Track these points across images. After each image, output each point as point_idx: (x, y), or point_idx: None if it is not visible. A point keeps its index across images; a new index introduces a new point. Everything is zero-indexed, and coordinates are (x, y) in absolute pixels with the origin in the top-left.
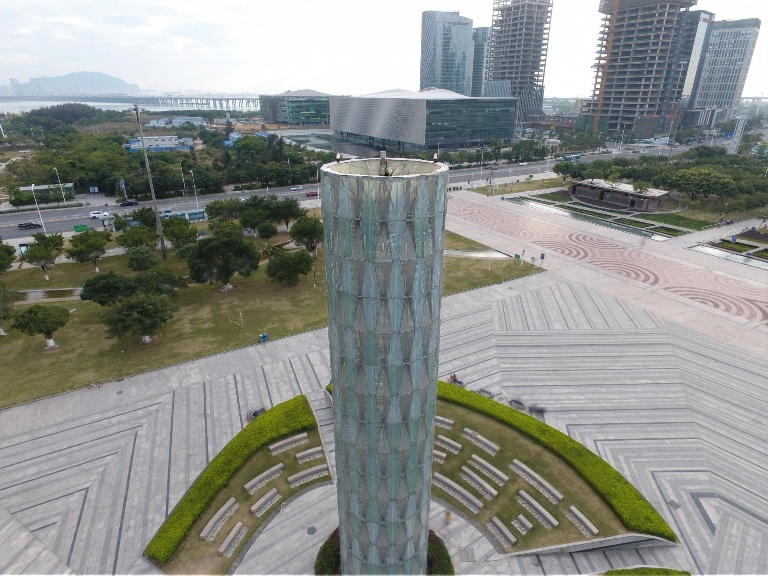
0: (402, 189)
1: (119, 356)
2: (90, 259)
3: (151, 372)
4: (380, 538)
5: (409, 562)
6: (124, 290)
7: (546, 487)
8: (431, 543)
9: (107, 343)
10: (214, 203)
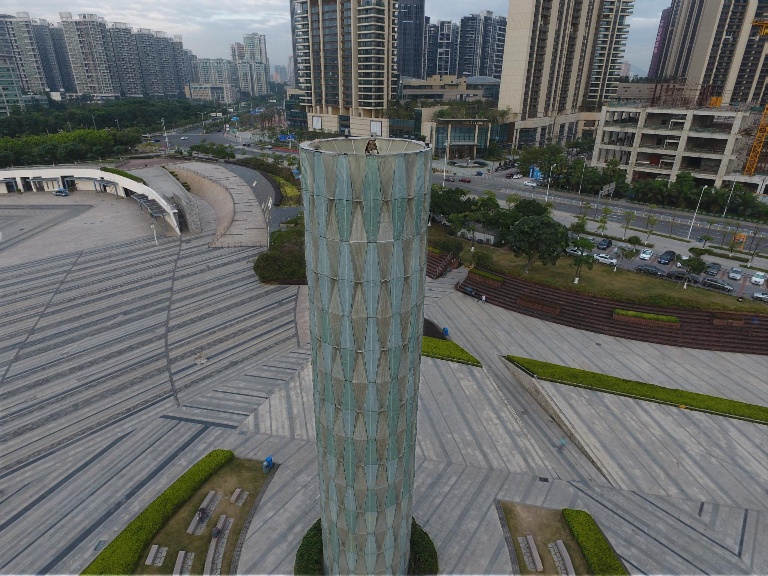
0: None
1: None
2: None
3: None
4: None
5: None
6: None
7: None
8: None
9: None
10: None
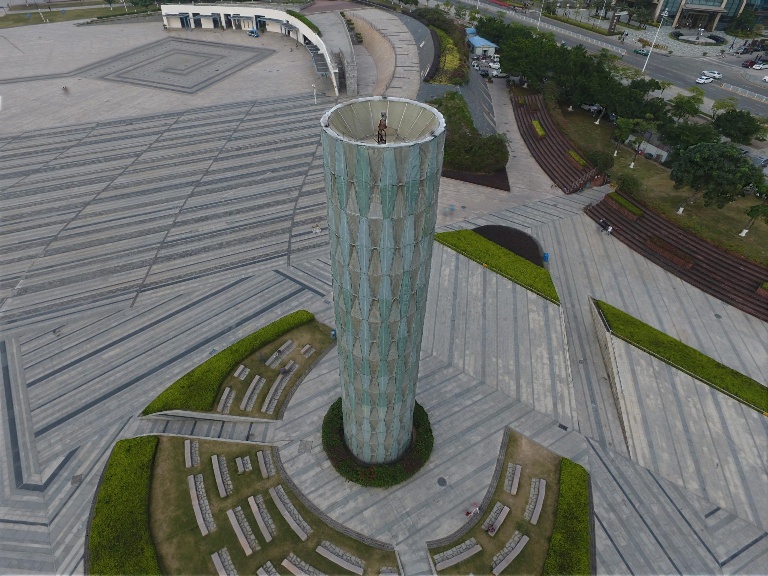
0: None
1: None
2: None
3: None
4: None
5: None
6: None
7: (196, 491)
8: (335, 446)
9: None
10: None
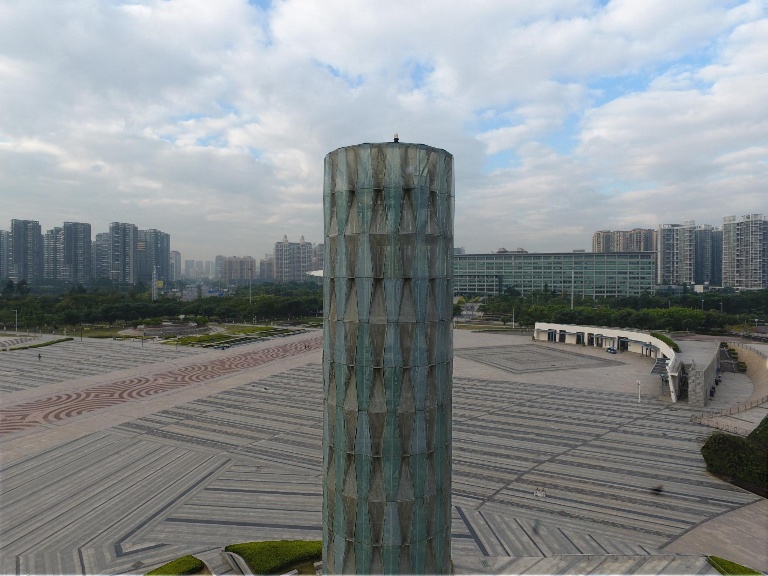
0: None
1: None
2: None
3: None
4: None
5: None
6: None
7: None
8: None
9: None
10: None
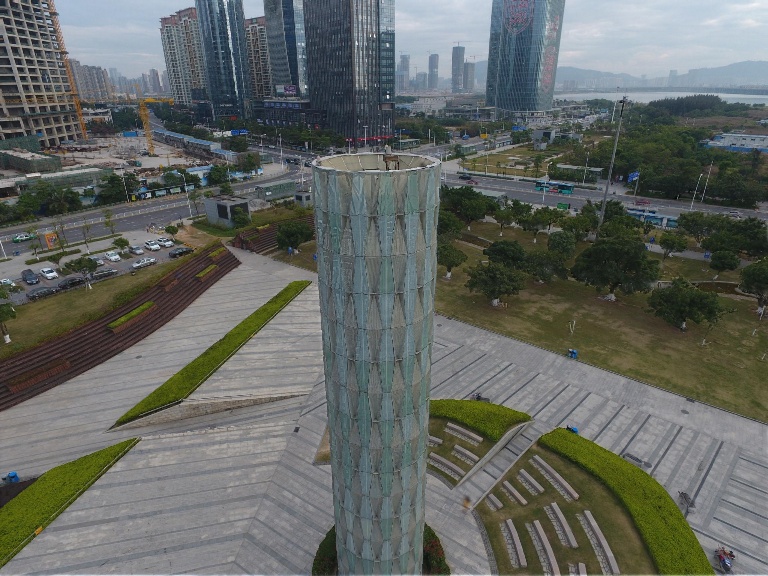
0: (320, 179)
1: (468, 304)
2: (532, 230)
3: (469, 325)
4: (334, 504)
5: (353, 557)
6: (514, 259)
7: None
8: None
9: (473, 292)
10: (692, 214)
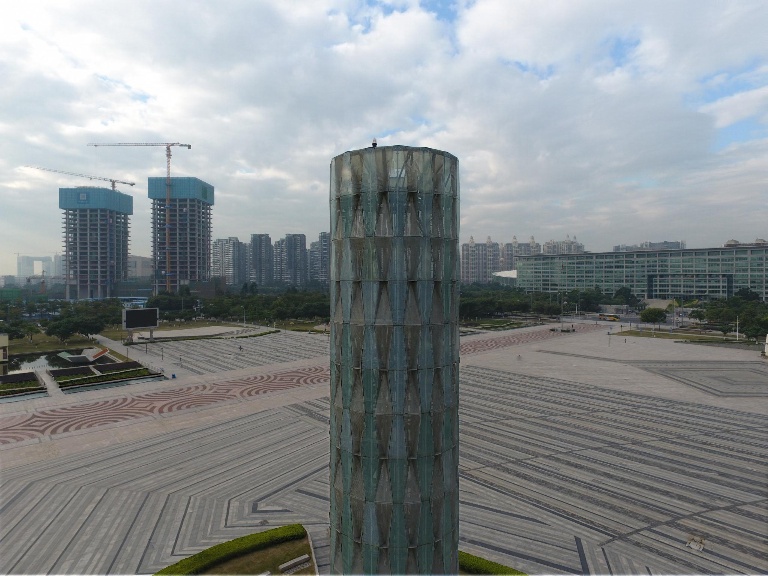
0: None
1: None
2: None
3: None
4: None
5: None
6: None
7: None
8: None
9: None
10: None
